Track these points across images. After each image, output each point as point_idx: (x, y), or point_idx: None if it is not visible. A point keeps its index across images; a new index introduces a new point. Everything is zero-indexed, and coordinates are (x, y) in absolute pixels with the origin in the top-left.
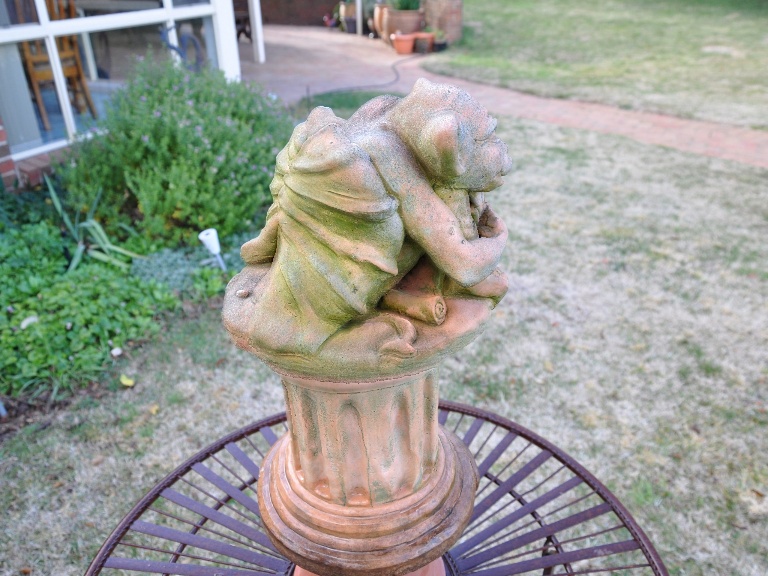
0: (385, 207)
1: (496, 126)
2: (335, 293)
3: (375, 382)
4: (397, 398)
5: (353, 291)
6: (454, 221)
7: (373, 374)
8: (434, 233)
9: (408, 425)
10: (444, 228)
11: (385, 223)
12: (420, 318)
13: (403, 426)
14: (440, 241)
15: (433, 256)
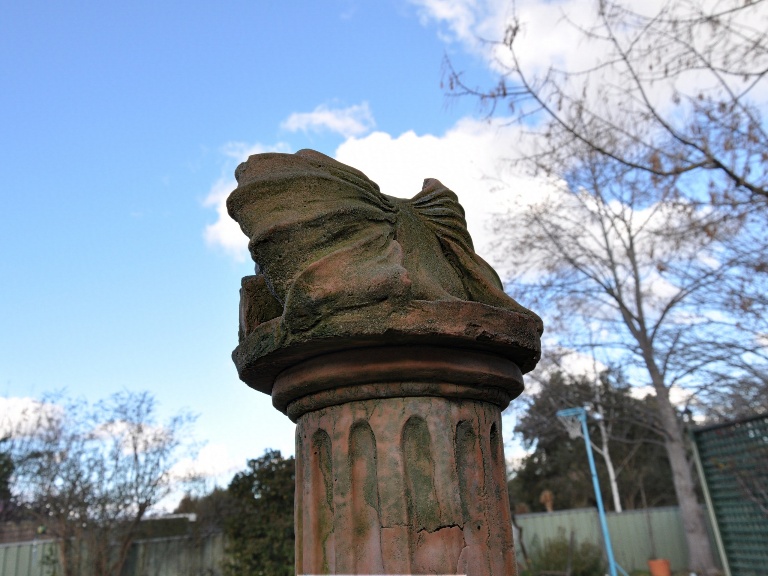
0: None
1: None
2: None
3: None
4: None
5: None
6: None
7: None
8: None
9: None
10: None
11: None
12: None
13: None
14: None
15: None
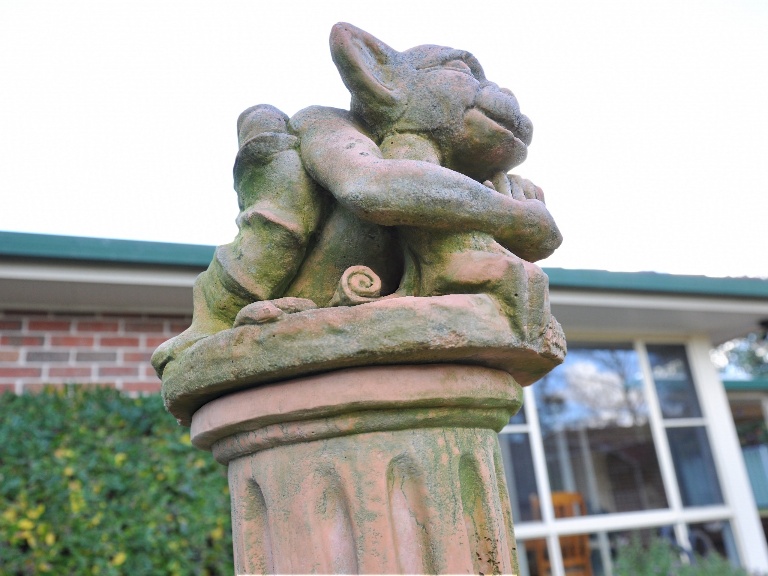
0: (265, 134)
1: (455, 55)
2: (218, 263)
3: (253, 401)
4: (329, 480)
5: (238, 258)
6: (362, 140)
7: (225, 360)
8: (325, 153)
9: (356, 555)
10: (340, 145)
11: (275, 161)
12: (334, 300)
13: (354, 563)
14: (331, 159)
15: (325, 183)
